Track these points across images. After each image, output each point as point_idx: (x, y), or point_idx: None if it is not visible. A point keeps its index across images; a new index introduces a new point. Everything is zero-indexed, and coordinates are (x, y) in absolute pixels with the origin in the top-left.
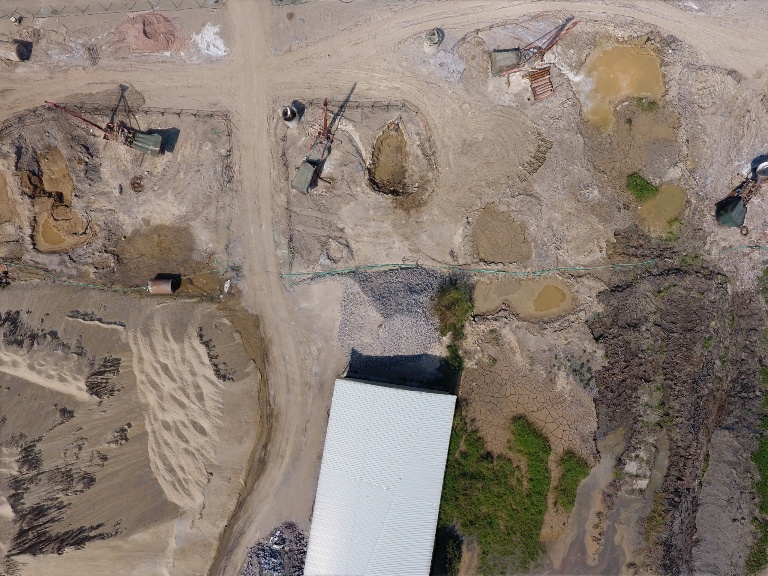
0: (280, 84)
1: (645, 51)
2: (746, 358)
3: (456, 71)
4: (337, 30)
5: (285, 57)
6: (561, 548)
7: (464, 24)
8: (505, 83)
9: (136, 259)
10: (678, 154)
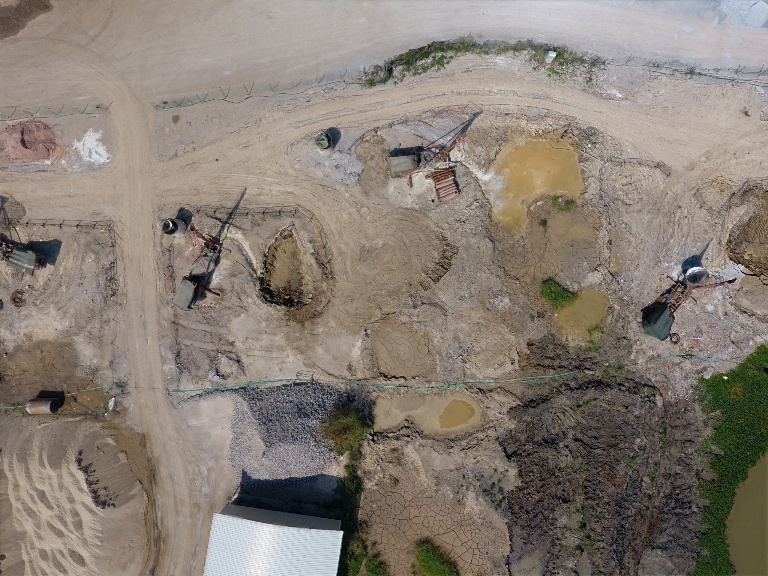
0: (166, 191)
1: (562, 145)
2: (681, 471)
3: (353, 173)
4: (226, 133)
5: (171, 163)
6: None
7: (362, 122)
8: (407, 184)
9: (18, 376)
10: (599, 257)
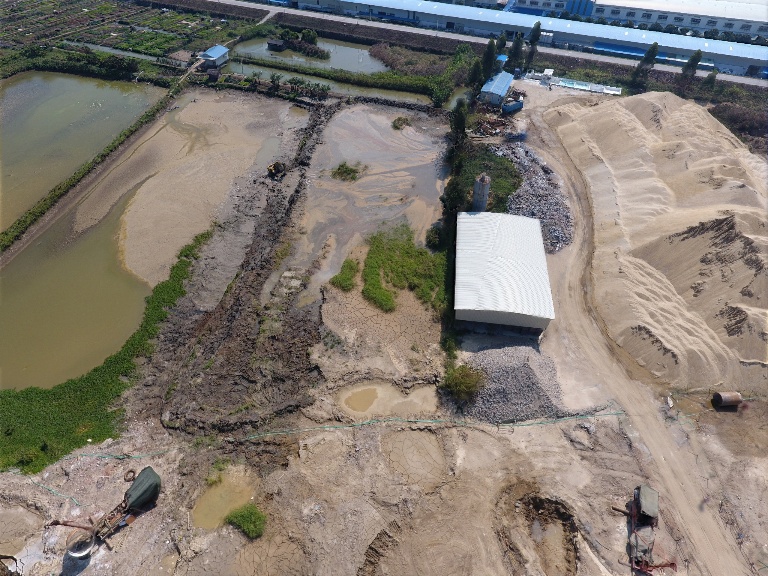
0: None
1: None
2: (164, 362)
3: None
4: None
5: None
6: (354, 242)
7: None
8: None
9: (765, 424)
10: (188, 572)
